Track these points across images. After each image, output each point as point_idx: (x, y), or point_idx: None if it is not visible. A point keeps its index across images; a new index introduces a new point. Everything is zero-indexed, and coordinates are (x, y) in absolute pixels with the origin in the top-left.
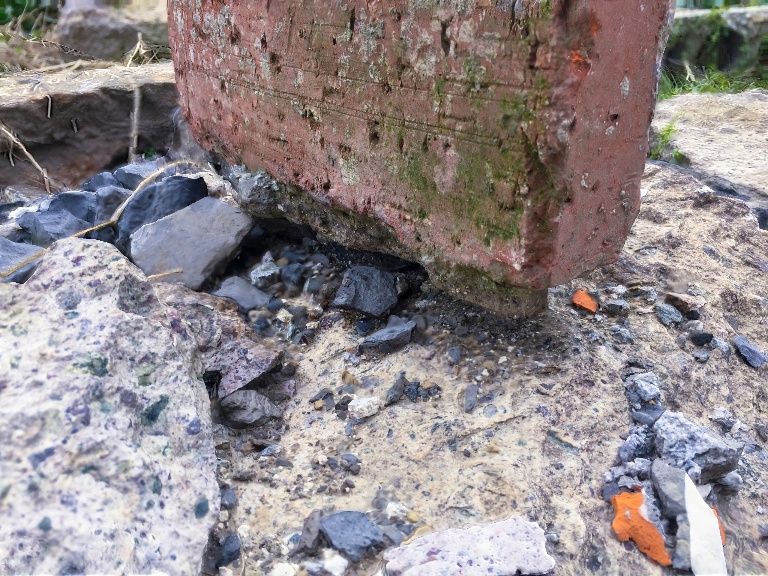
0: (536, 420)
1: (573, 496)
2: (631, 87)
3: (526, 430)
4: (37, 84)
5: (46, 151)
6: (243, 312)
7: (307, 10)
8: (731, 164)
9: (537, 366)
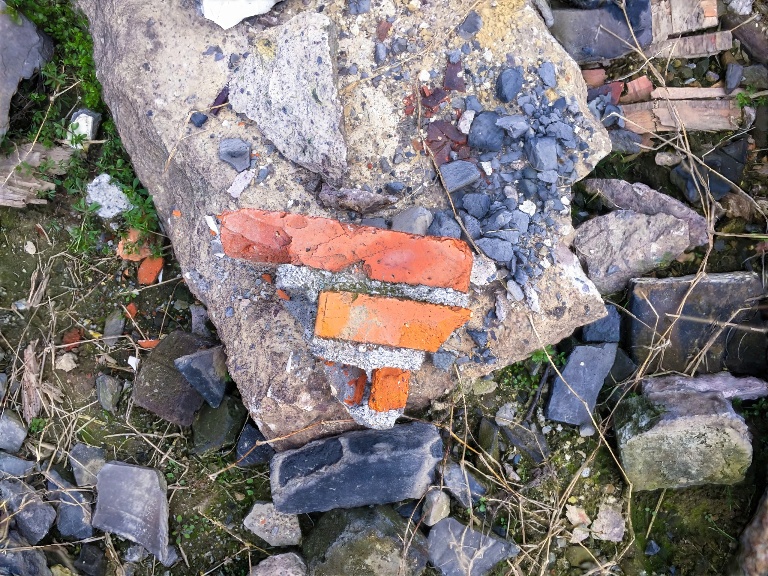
0: None
1: None
2: None
3: None
4: None
5: None
6: None
7: None
8: None
9: None
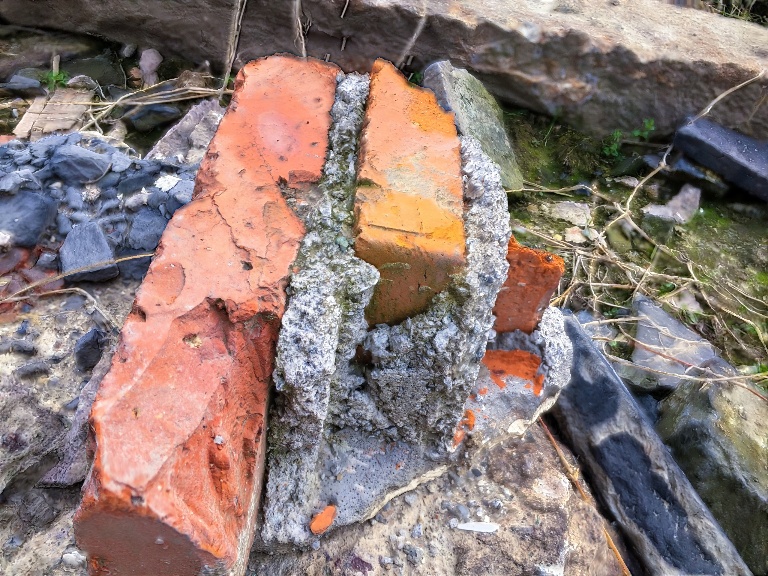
0: None
1: None
2: None
3: None
4: None
5: (334, 41)
6: None
7: None
8: None
9: None
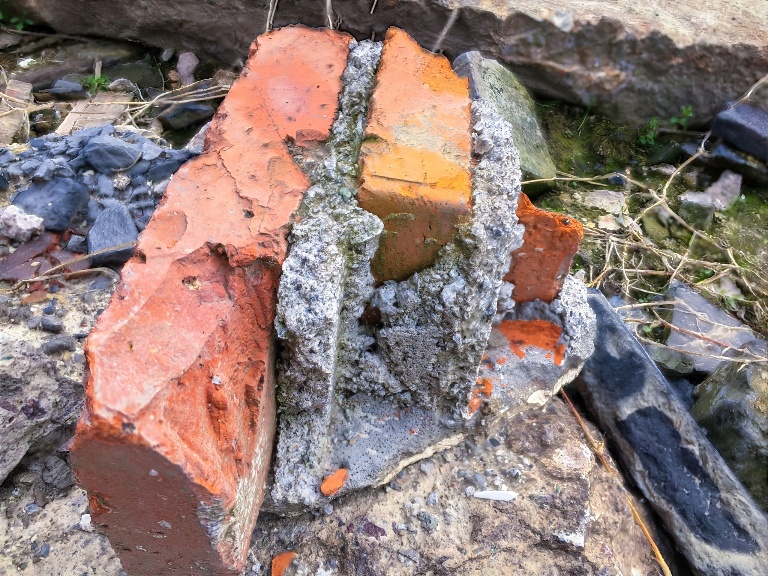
0: None
1: None
2: (175, 526)
3: None
4: None
5: (365, 38)
6: None
7: None
8: None
9: None
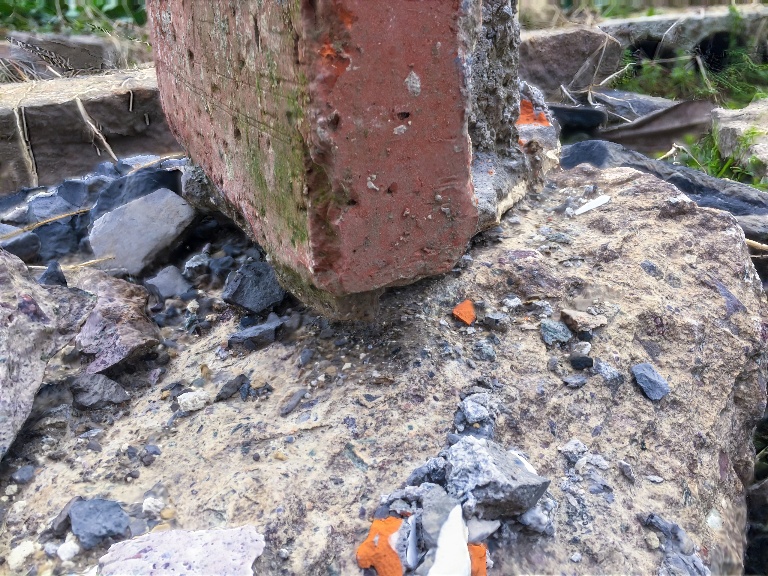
0: (338, 431)
1: (338, 514)
2: (424, 83)
3: (325, 440)
4: (125, 80)
5: (129, 142)
6: (162, 300)
7: (197, 7)
8: None
9: (371, 376)
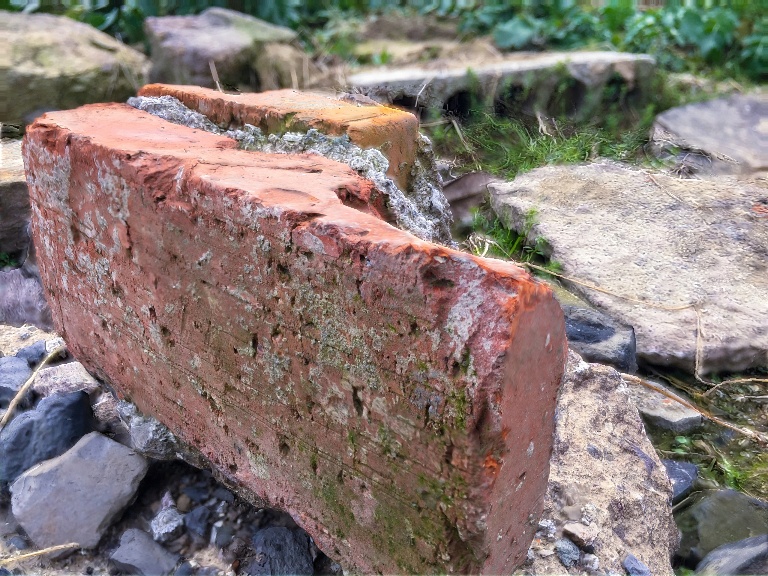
0: None
1: None
2: (535, 445)
3: None
4: None
5: None
6: None
7: (202, 309)
8: (589, 251)
9: None
